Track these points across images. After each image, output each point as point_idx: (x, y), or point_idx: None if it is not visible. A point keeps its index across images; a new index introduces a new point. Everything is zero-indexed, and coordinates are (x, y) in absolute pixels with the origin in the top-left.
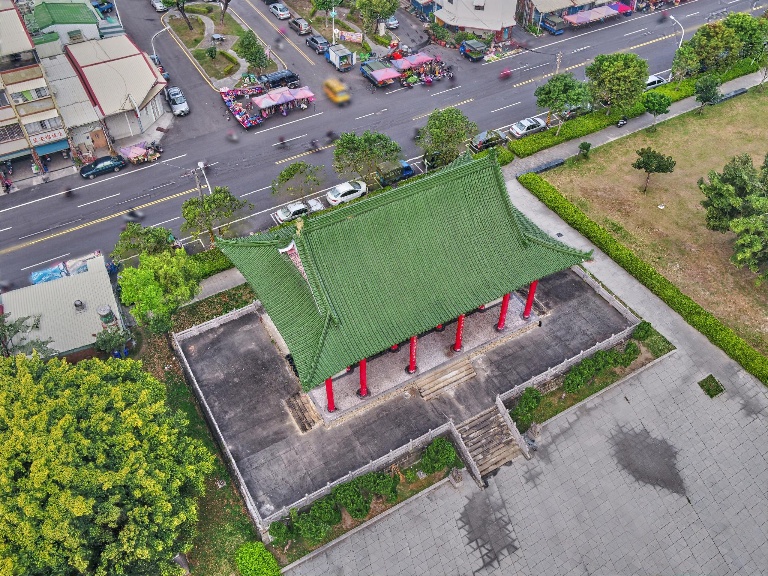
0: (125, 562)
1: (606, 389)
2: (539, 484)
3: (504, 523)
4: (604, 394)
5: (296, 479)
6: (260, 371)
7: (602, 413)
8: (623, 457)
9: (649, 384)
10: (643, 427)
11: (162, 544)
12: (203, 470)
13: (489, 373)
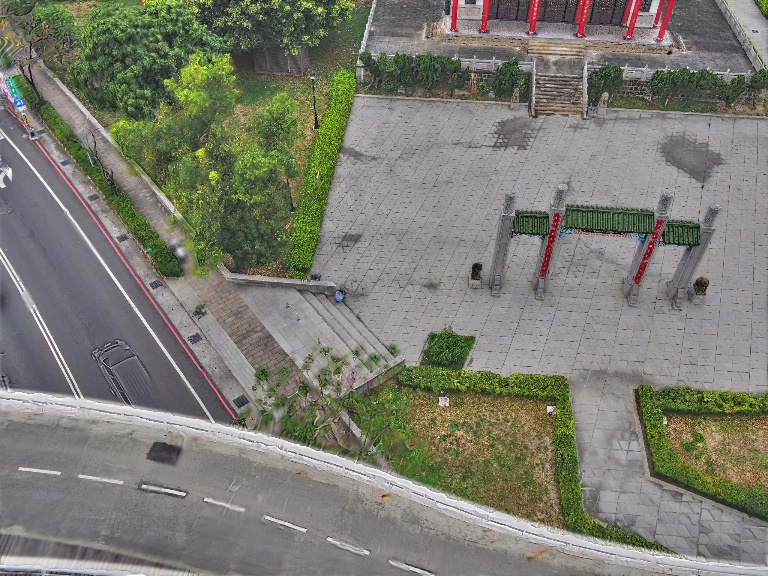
0: (264, 6)
1: (696, 113)
2: (579, 132)
3: (530, 136)
4: (691, 115)
5: (400, 54)
6: (424, 7)
7: (677, 123)
8: (668, 147)
9: (742, 126)
10: (707, 142)
11: (289, 8)
12: (341, 5)
13: (595, 61)
